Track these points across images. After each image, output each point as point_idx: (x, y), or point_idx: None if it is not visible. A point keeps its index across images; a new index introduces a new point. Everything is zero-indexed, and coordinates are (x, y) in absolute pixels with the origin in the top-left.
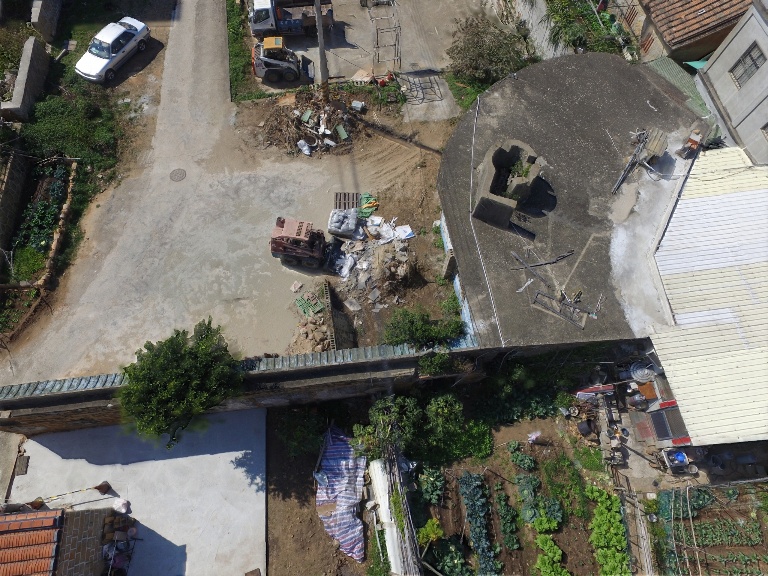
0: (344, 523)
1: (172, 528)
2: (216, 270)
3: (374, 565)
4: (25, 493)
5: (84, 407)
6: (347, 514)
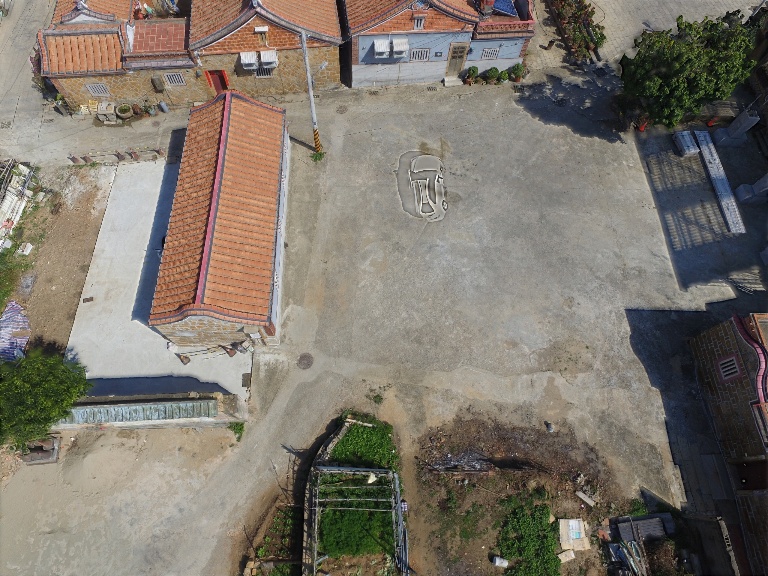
0: (8, 322)
1: (139, 331)
2: (67, 575)
3: (1, 298)
4: (242, 360)
5: (131, 396)
6: (2, 327)
